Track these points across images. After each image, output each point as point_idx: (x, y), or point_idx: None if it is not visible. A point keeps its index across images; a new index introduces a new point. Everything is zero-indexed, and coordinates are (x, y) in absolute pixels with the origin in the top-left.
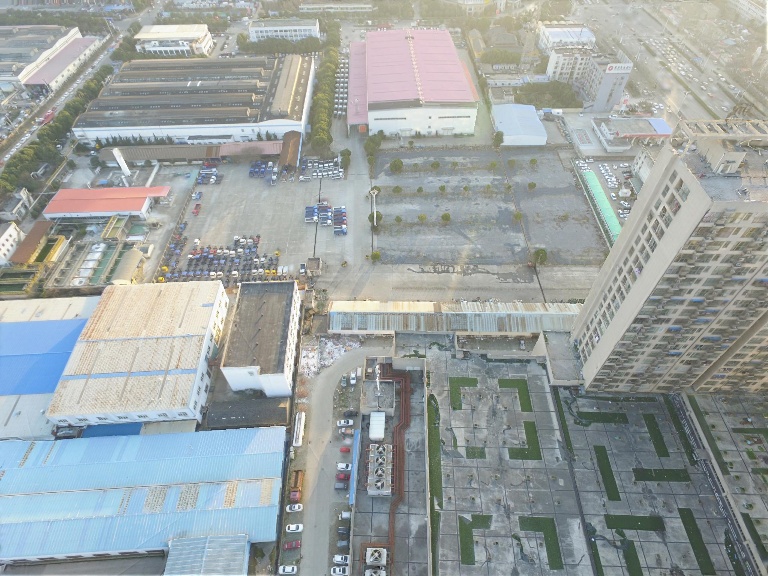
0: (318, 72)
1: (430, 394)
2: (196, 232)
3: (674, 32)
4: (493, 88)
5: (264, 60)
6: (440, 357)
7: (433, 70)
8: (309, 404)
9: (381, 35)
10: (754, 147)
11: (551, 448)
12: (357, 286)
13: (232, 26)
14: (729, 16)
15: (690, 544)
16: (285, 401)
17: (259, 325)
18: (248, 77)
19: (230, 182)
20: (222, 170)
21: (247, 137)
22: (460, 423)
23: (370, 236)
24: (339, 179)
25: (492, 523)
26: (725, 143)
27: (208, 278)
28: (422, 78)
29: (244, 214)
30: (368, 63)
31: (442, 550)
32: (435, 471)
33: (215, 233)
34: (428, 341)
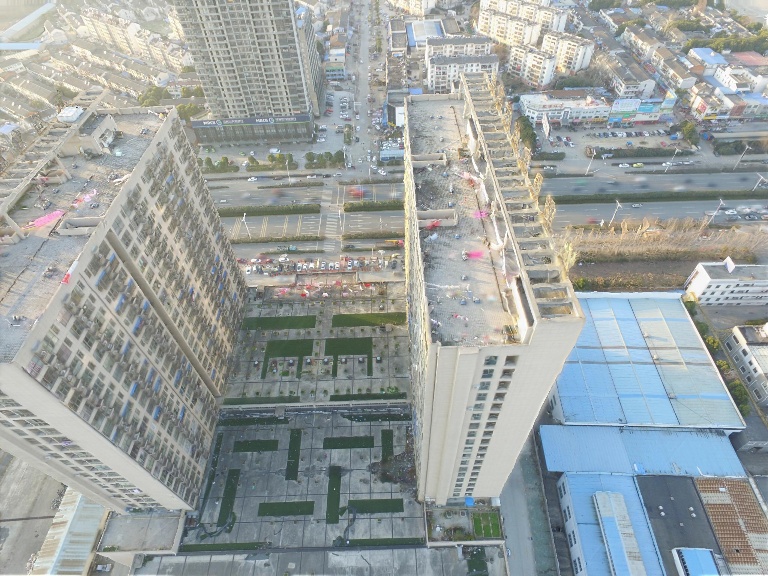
0: None
1: None
2: None
3: None
4: None
5: None
6: None
7: None
8: None
9: None
10: None
11: (253, 571)
12: None
13: None
14: None
15: (352, 449)
16: None
17: None
18: None
19: None
20: None
21: None
22: None
23: None
24: None
25: None
26: None
27: None
28: None
29: None
30: None
31: None
32: None
33: None
34: None
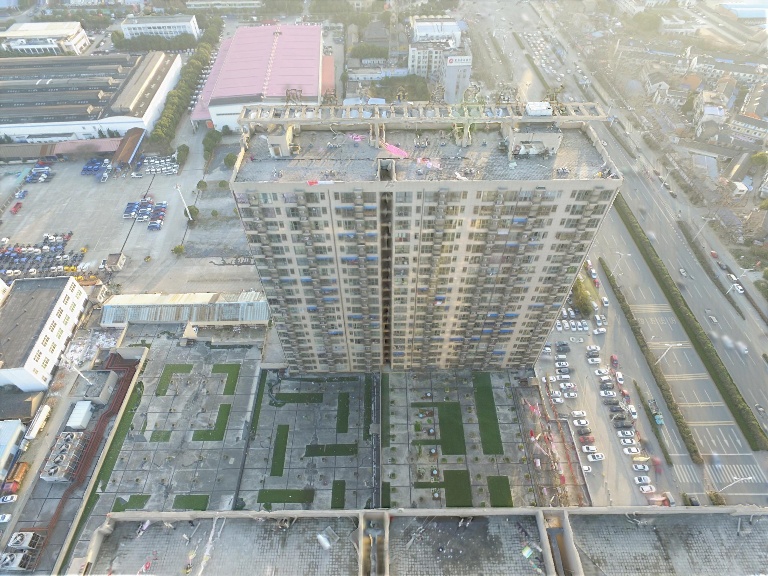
0: (181, 68)
1: (139, 381)
2: (9, 231)
3: (551, 25)
4: (349, 82)
5: (125, 57)
6: (165, 345)
7: (288, 65)
8: (60, 397)
9: (251, 31)
10: (336, 131)
11: (236, 429)
12: (153, 280)
13: (115, 23)
14: (607, 9)
15: None
16: (35, 395)
17: (18, 321)
18: (104, 74)
19: (61, 180)
20: (56, 168)
21: (90, 135)
22: (157, 408)
23: (184, 230)
24: (172, 175)
25: (147, 503)
26: (277, 127)
27: (5, 276)
28: (273, 73)
29: (64, 212)
30: (227, 59)
31: (86, 531)
32: (112, 455)
33: (28, 231)
34: (160, 330)
